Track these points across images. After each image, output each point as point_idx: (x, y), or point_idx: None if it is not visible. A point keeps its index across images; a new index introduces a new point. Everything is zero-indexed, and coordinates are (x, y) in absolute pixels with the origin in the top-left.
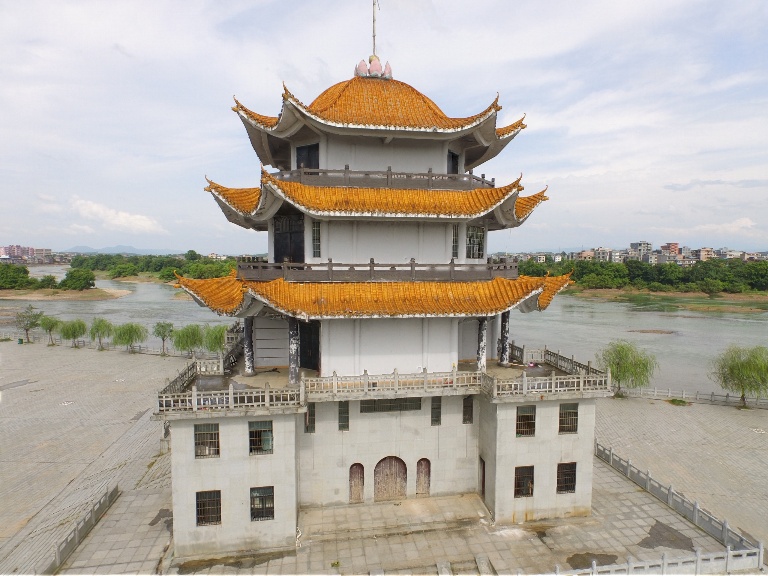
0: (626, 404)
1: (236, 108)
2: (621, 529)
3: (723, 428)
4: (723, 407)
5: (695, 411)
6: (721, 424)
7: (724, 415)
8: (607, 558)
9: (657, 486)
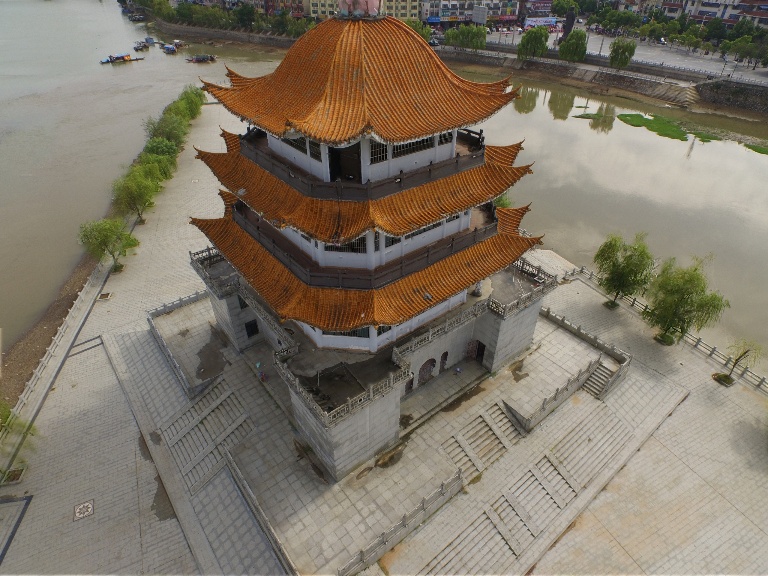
0: (140, 265)
1: (518, 96)
2: None
3: (191, 232)
4: (139, 229)
5: (153, 239)
6: (182, 232)
7: (160, 230)
8: None
9: None
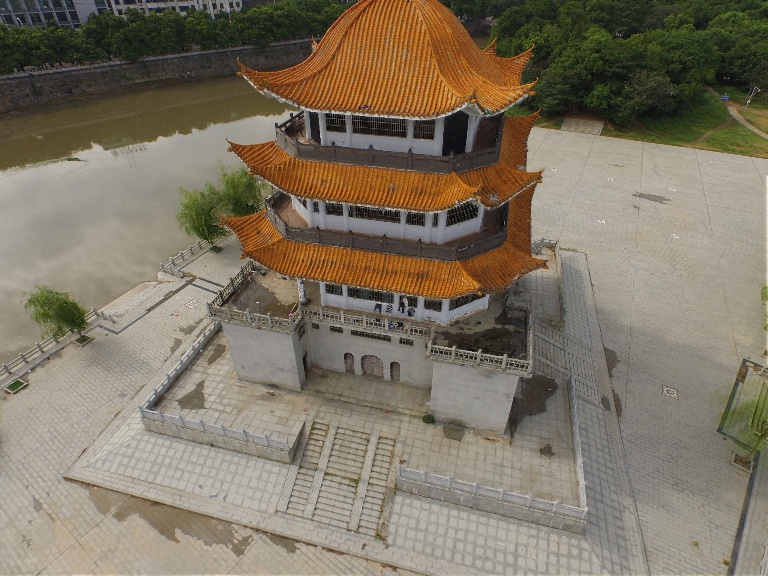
0: None
1: None
2: (217, 383)
3: None
4: None
5: None
6: None
7: None
8: (212, 360)
9: (214, 427)
